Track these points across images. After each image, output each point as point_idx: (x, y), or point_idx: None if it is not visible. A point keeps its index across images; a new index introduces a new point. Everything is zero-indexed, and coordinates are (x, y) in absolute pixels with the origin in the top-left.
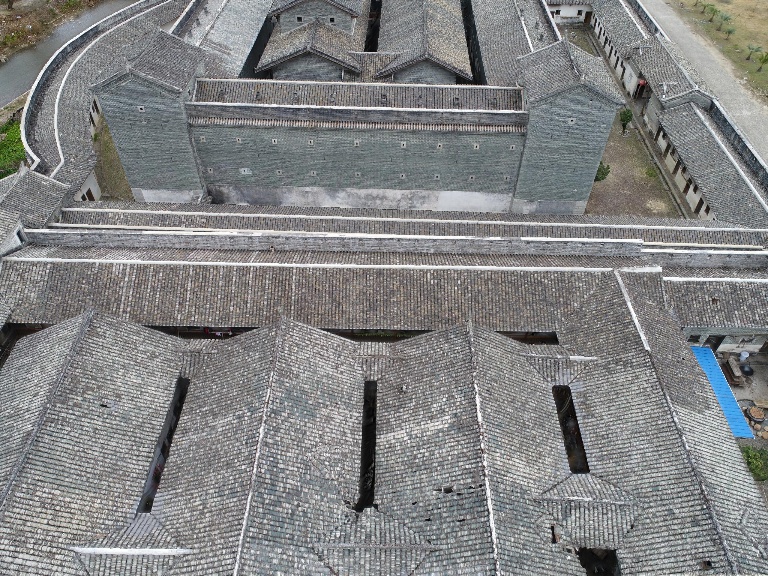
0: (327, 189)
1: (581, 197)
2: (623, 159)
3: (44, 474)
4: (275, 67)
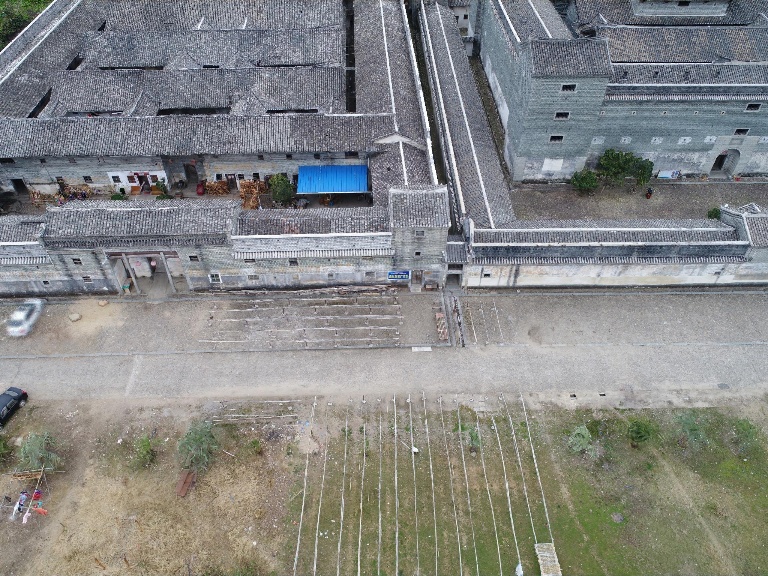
0: None
1: None
2: None
3: (270, 4)
4: (570, 2)
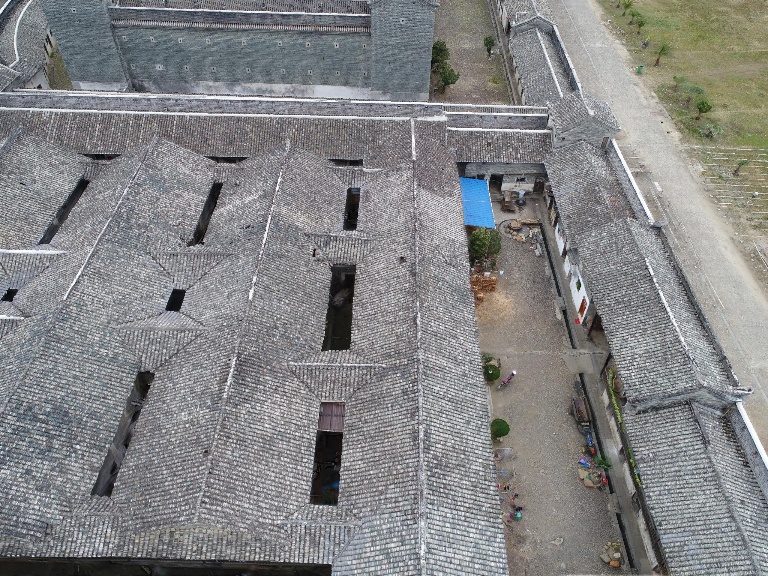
0: (226, 83)
1: (423, 89)
2: (482, 75)
3: None
4: None
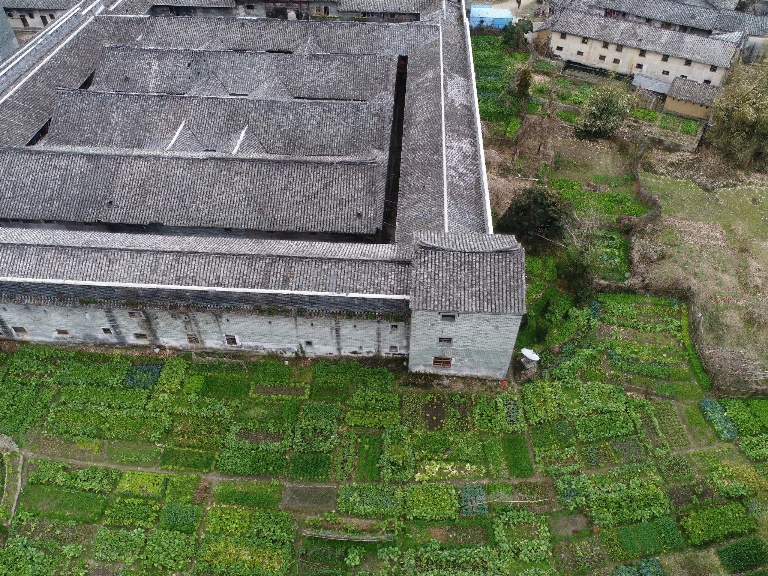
0: None
1: (12, 36)
2: None
3: None
4: None
